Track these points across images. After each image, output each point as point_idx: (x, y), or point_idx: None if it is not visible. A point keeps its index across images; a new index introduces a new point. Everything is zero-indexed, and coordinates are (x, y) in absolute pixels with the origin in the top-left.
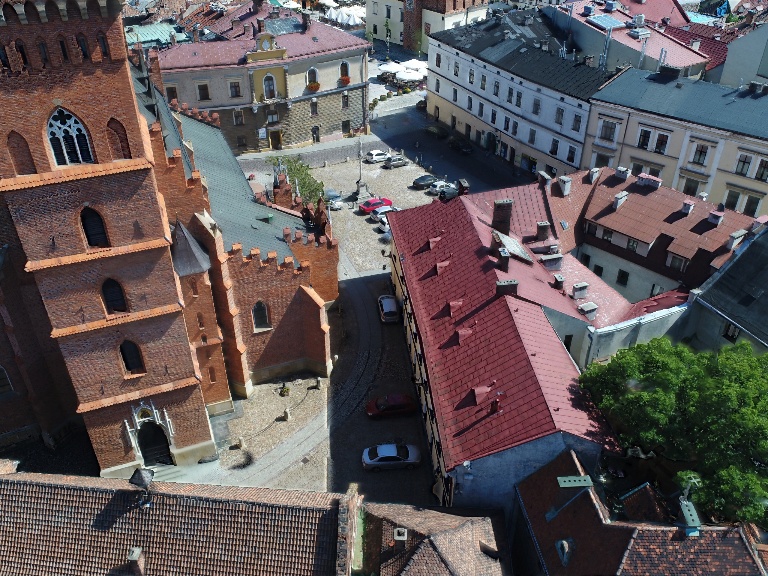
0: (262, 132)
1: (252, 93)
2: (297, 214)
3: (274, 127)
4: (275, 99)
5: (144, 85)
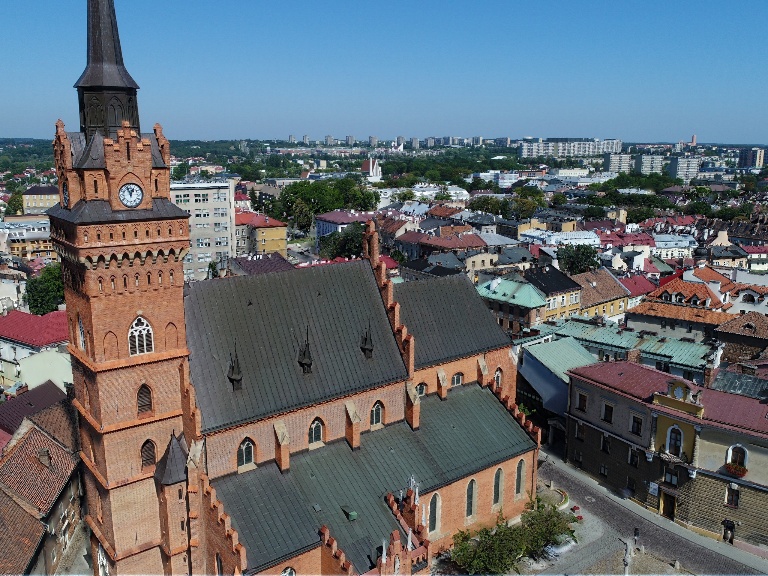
0: (654, 487)
1: (651, 438)
2: (415, 541)
3: (669, 489)
4: (678, 458)
5: (366, 355)
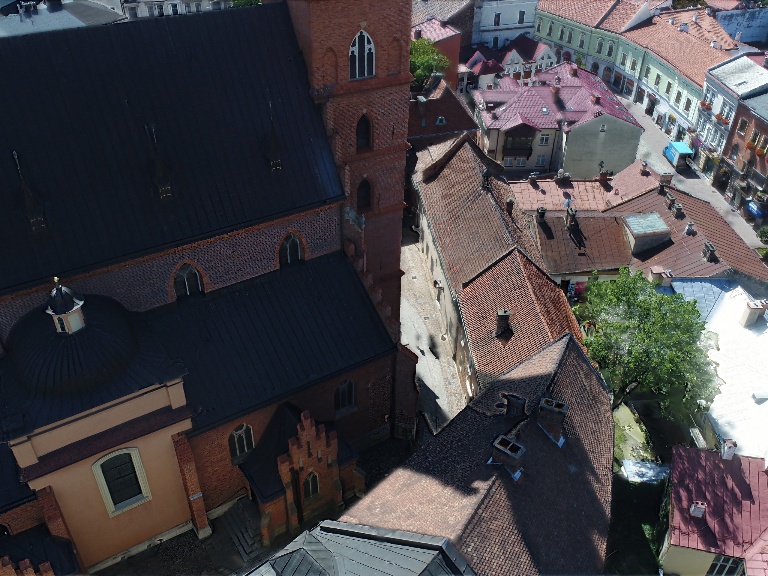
0: None
1: None
2: None
3: None
4: None
5: None
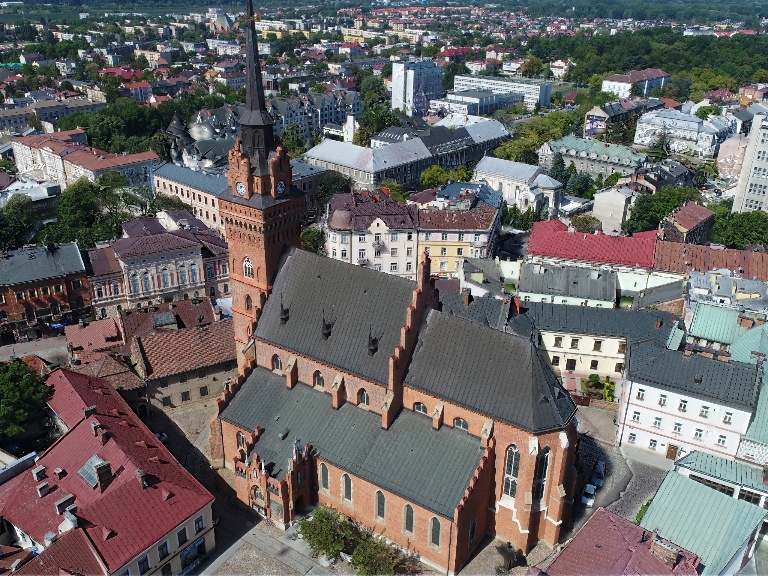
0: None
1: None
2: None
3: None
4: None
5: None
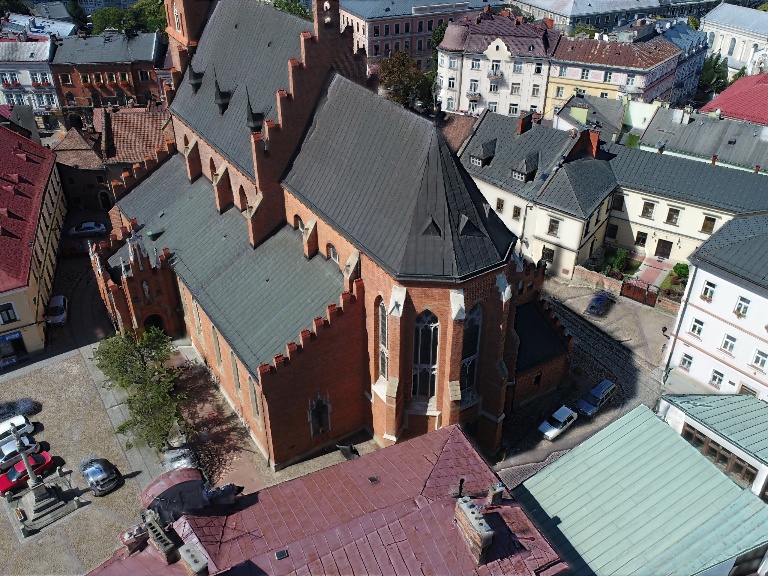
0: None
1: None
2: None
3: None
4: None
5: None
